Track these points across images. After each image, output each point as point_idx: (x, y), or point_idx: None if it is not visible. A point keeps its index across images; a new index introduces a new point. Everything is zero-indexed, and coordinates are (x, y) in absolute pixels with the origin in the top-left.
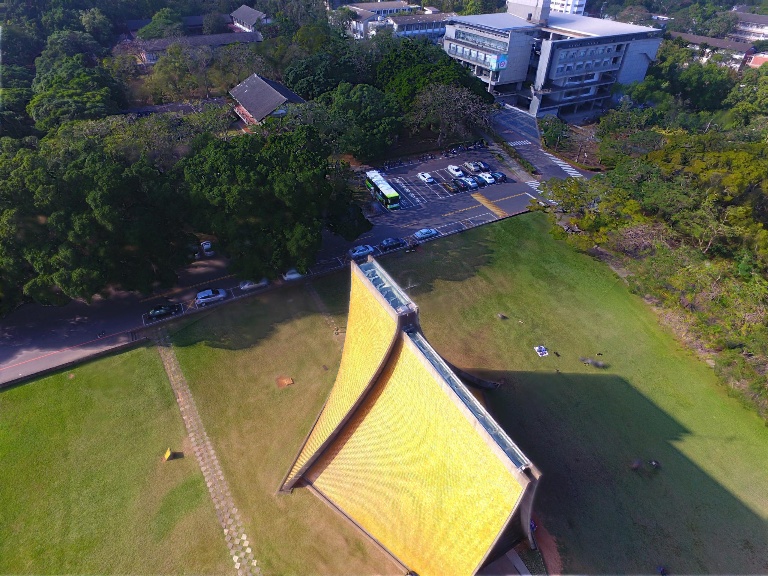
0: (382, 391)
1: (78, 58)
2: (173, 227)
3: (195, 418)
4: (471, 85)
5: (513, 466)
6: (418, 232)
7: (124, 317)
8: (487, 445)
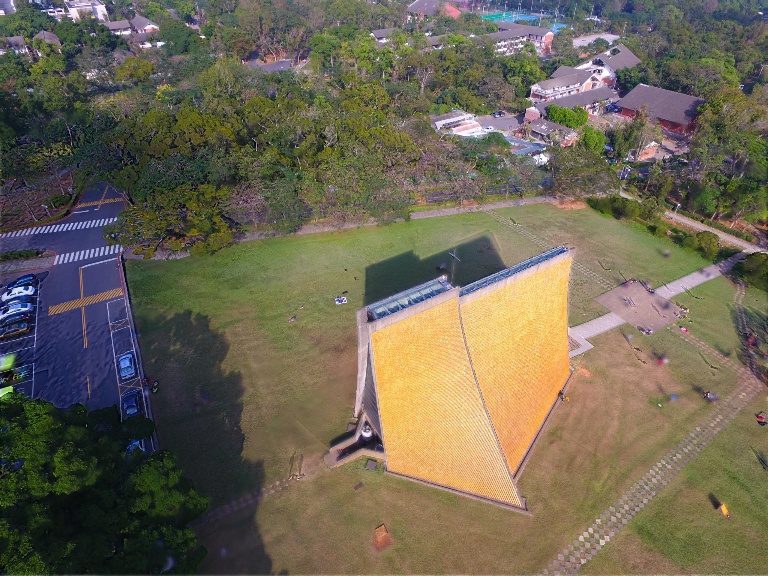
0: None
1: None
2: None
3: None
4: None
5: None
6: (124, 371)
7: None
8: None
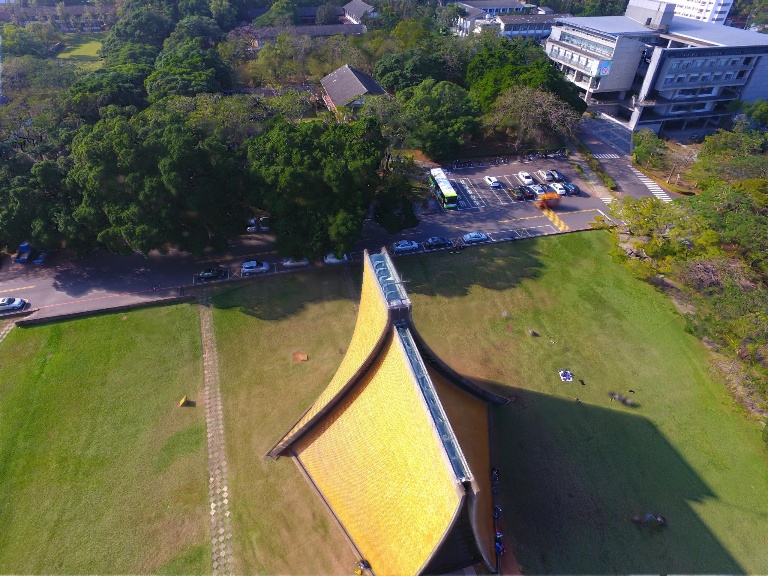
0: (370, 380)
1: (196, 41)
2: (232, 199)
3: (214, 374)
4: (563, 90)
5: (453, 476)
6: (467, 235)
7: (179, 274)
8: (439, 450)
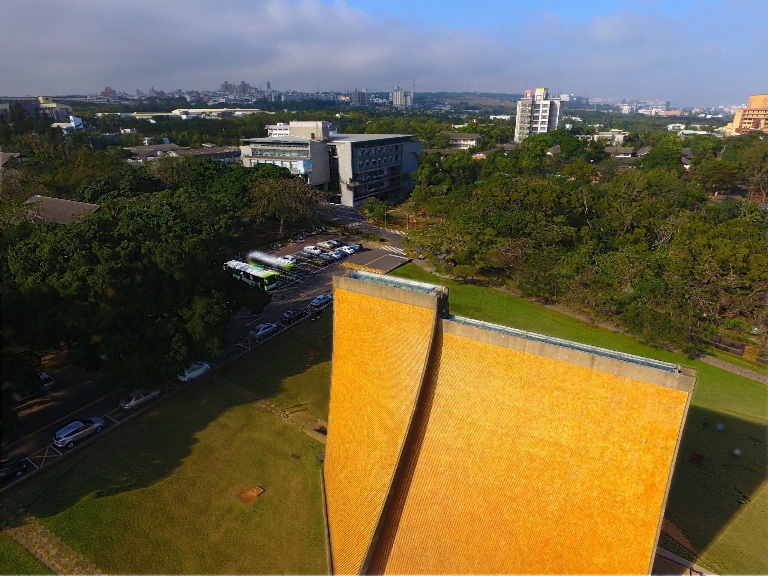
0: (430, 410)
1: None
2: None
3: None
4: None
5: (668, 373)
6: (315, 299)
7: None
8: (618, 376)
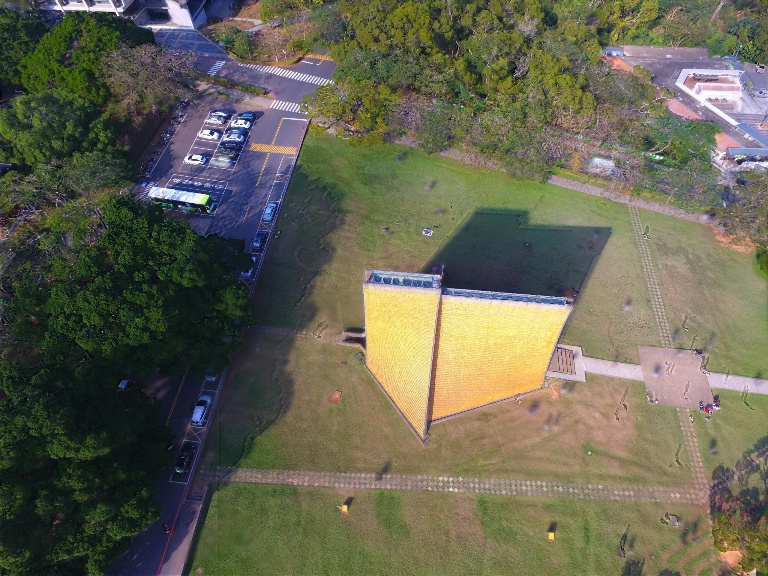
0: (439, 336)
1: None
2: None
3: (323, 477)
4: (123, 31)
5: (562, 306)
6: (265, 215)
7: (157, 500)
8: (539, 308)
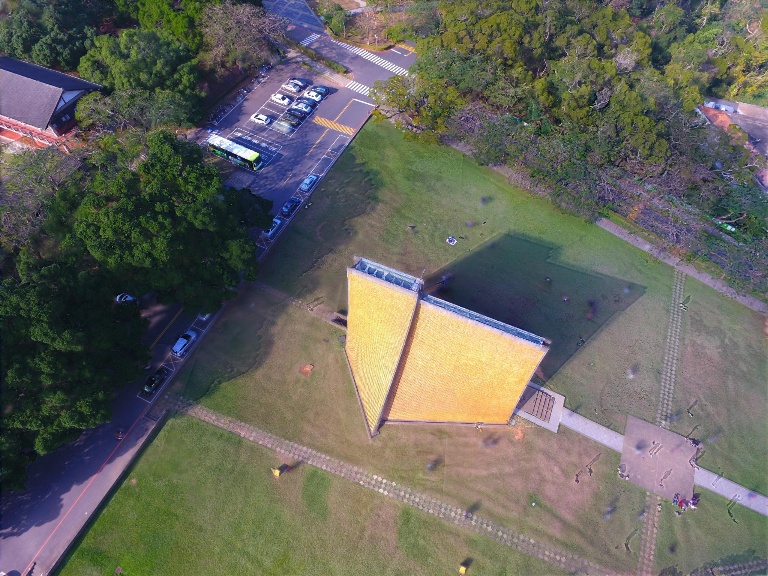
0: (412, 340)
1: None
2: (107, 307)
3: (268, 437)
4: None
5: (537, 345)
6: (303, 185)
7: (121, 408)
8: (514, 341)
